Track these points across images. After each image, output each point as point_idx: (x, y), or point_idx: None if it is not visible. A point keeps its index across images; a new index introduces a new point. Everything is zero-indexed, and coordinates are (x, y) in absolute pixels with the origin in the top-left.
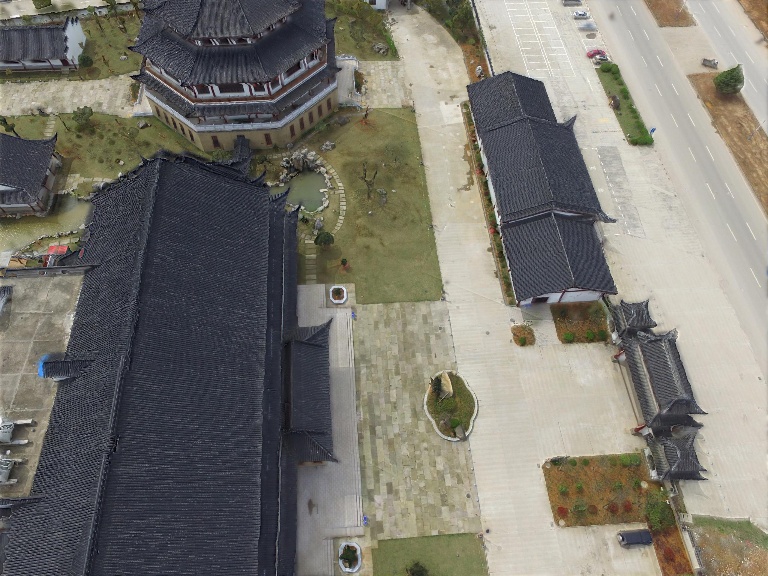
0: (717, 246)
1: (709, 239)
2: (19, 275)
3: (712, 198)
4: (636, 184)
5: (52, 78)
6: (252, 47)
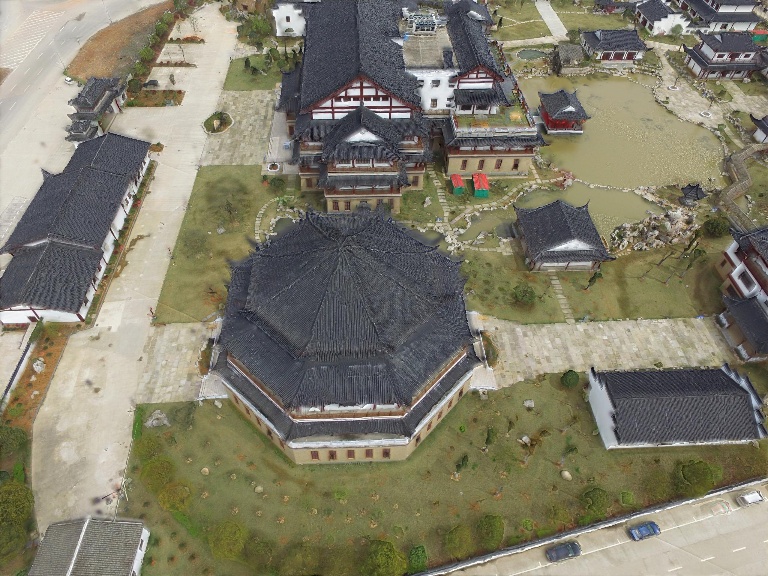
0: None
1: None
2: None
3: None
4: None
5: None
6: None
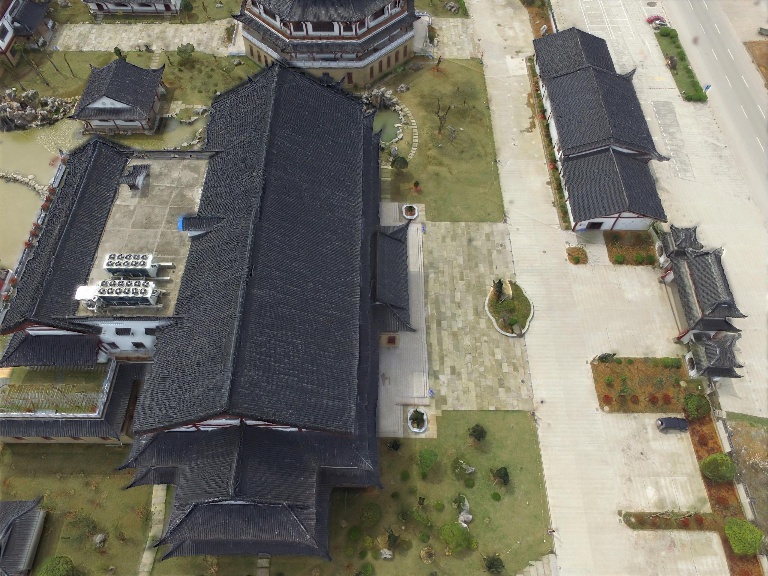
0: (763, 192)
1: (756, 185)
2: (155, 157)
3: (761, 150)
4: (689, 135)
5: (156, 21)
6: None
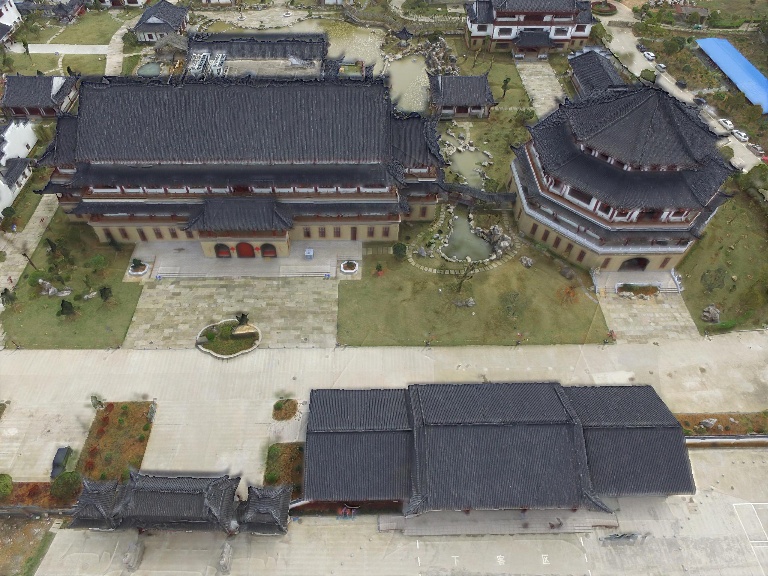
0: None
1: None
2: None
3: None
4: None
5: None
6: (580, 154)
